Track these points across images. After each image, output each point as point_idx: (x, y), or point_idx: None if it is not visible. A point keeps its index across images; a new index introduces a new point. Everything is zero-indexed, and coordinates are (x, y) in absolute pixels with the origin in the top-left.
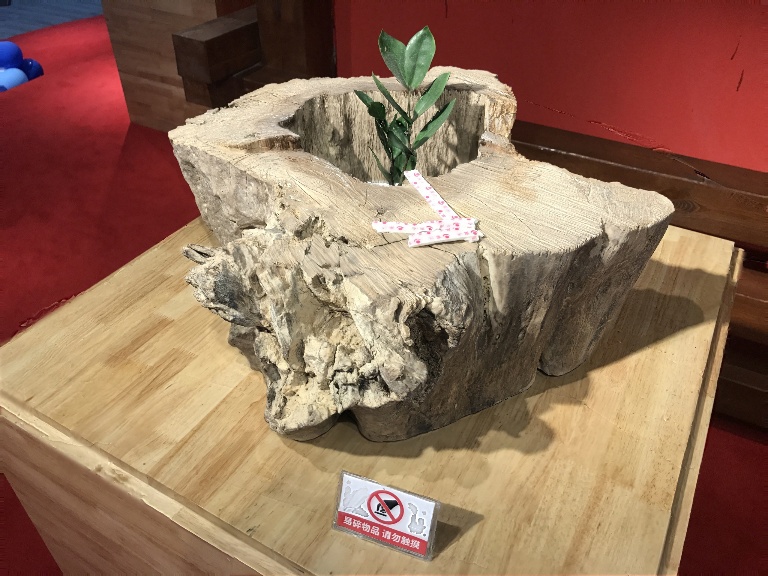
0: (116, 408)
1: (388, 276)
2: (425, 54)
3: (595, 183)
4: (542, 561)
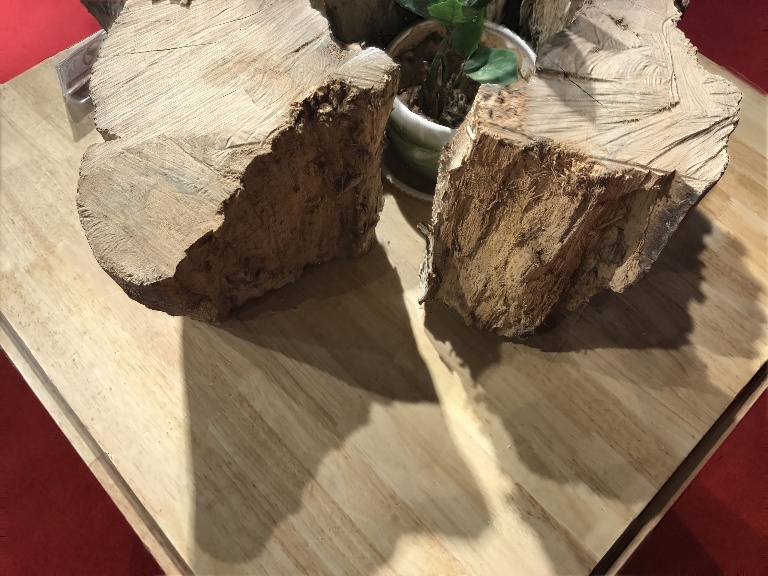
0: None
1: None
2: None
3: (218, 182)
4: (15, 165)
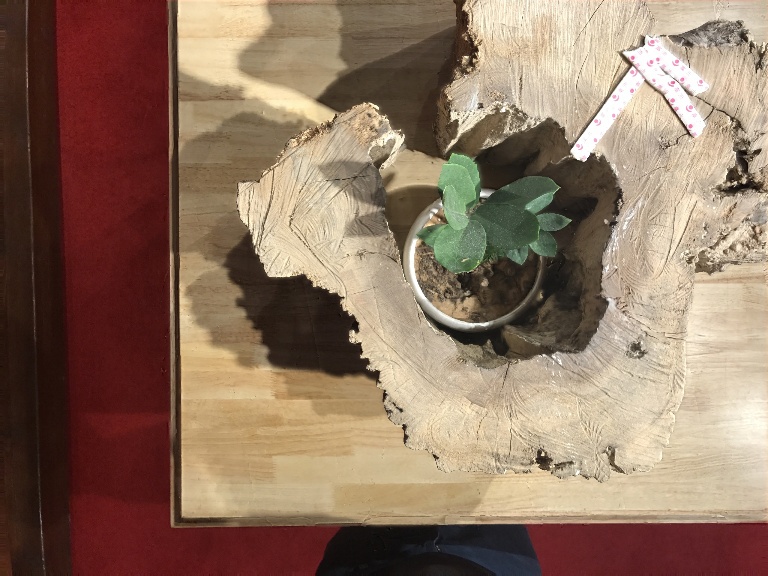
0: (744, 356)
1: (759, 83)
2: (450, 201)
3: None
4: None
